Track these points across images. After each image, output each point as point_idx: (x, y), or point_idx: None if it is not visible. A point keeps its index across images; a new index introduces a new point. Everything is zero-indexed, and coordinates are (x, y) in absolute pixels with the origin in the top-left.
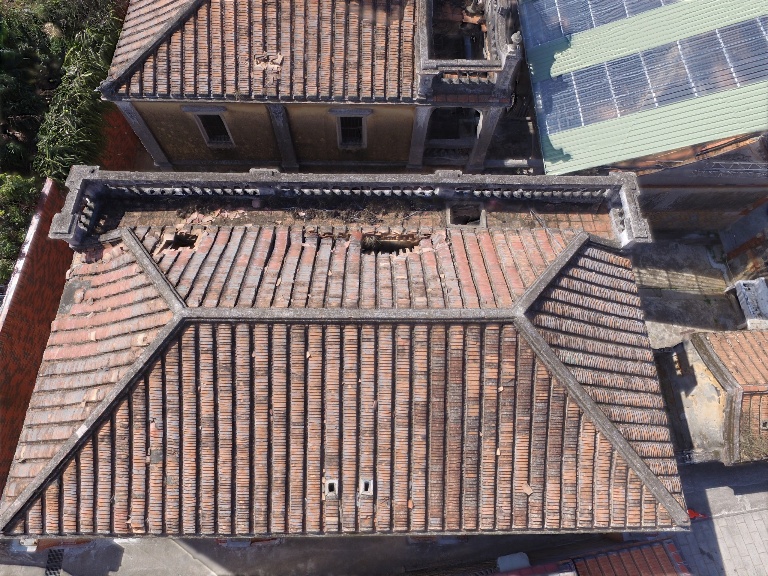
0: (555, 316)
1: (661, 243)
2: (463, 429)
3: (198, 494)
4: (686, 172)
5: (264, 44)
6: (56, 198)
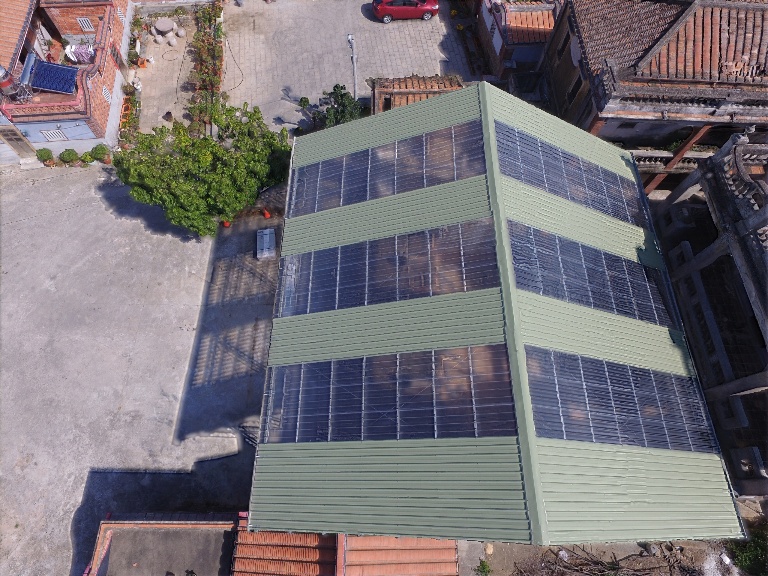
0: None
1: None
2: None
3: None
4: None
5: None
6: None
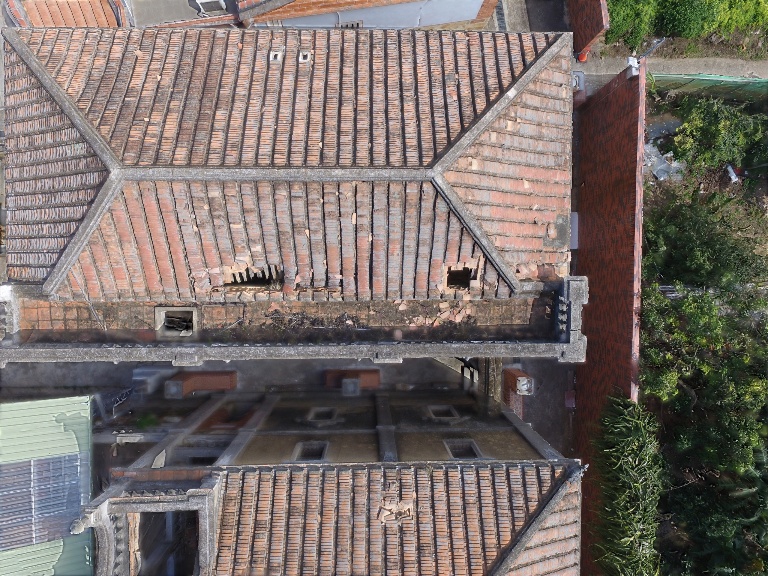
0: None
1: None
2: (187, 93)
3: (415, 55)
4: None
5: (402, 535)
6: (625, 384)
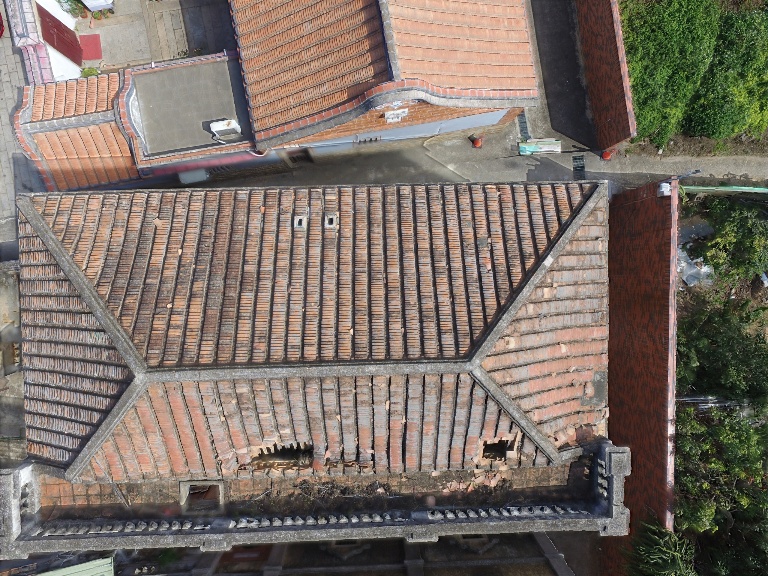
0: (109, 380)
1: None
2: (210, 270)
3: (445, 214)
4: None
5: None
6: (659, 508)
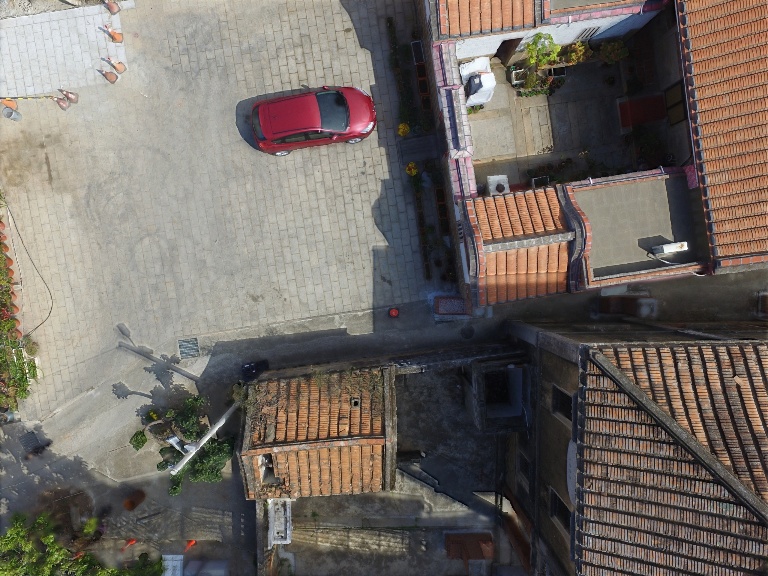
0: (736, 552)
1: None
2: None
3: None
4: None
5: None
6: None
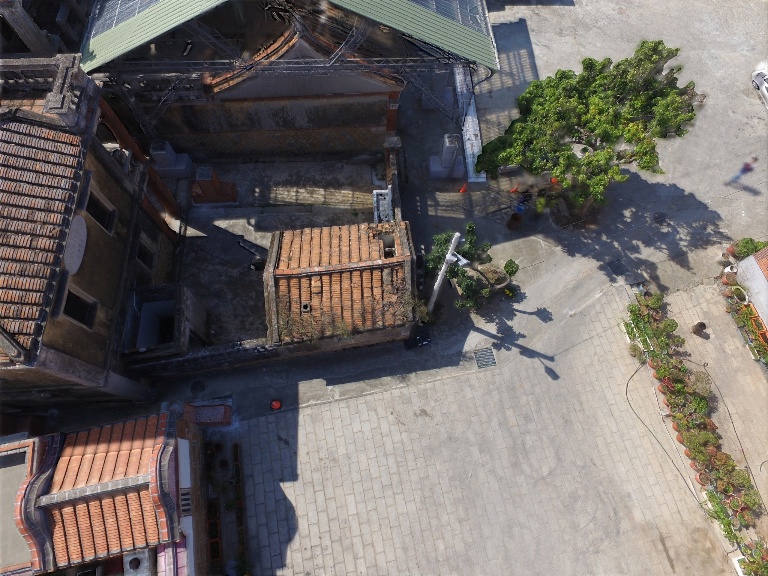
0: None
1: (328, 164)
2: None
3: None
4: (280, 81)
5: None
6: None
